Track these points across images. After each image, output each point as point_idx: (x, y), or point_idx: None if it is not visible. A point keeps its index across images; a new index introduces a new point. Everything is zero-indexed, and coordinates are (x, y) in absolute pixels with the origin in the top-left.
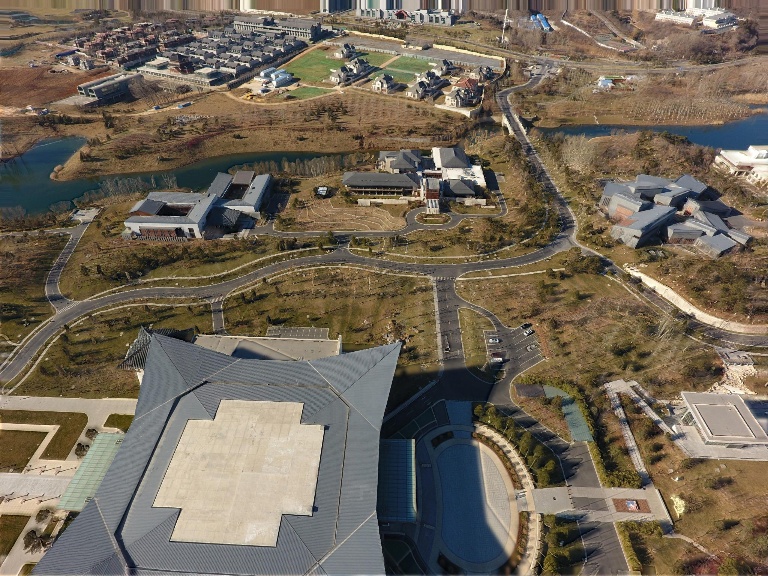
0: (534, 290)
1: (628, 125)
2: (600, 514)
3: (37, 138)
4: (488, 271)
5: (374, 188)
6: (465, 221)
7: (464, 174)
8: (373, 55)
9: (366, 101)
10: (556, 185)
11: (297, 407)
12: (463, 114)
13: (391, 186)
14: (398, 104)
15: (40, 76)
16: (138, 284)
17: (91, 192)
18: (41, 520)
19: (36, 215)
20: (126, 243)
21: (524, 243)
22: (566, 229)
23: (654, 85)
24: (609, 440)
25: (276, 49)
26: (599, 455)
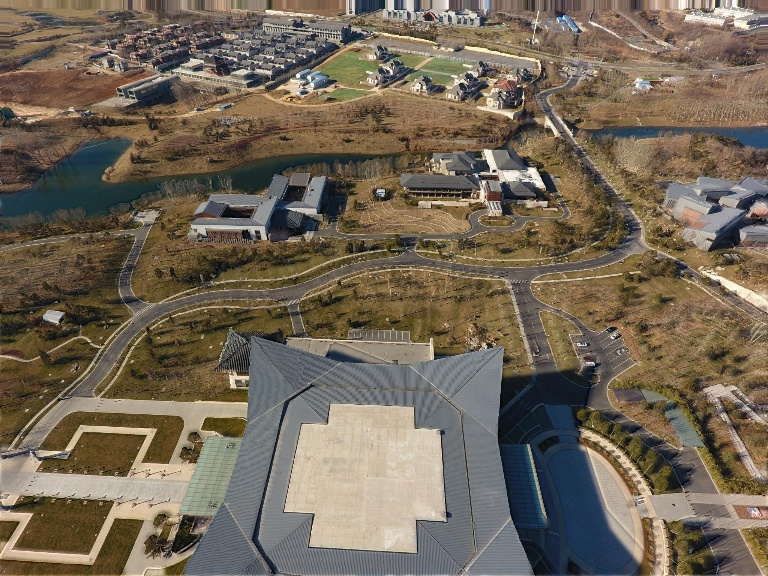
0: (613, 293)
1: (671, 127)
2: (723, 521)
3: (82, 140)
4: (562, 274)
5: (433, 190)
6: (529, 223)
7: (521, 176)
8: (406, 57)
9: (407, 103)
10: (614, 187)
11: (408, 411)
12: (506, 116)
13: (451, 188)
14: (440, 106)
15: (76, 78)
16: (210, 286)
17: (149, 194)
18: (159, 524)
19: (94, 217)
20: (192, 245)
21: (594, 246)
22: (633, 232)
23: (691, 87)
24: (719, 446)
25: (309, 51)
26: (713, 461)
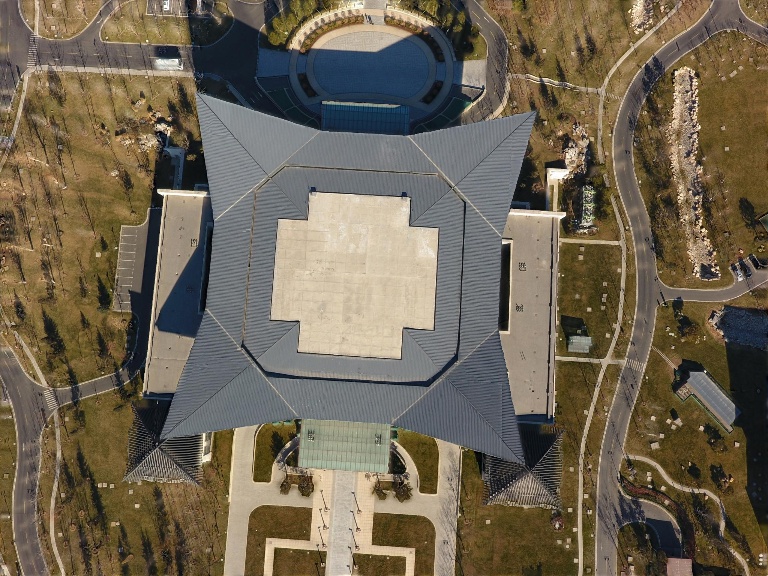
0: None
1: None
2: None
3: None
4: None
5: None
6: None
7: None
8: None
9: None
10: None
11: (285, 226)
12: None
13: None
14: None
15: None
16: (1, 543)
17: None
18: None
19: None
20: None
21: None
22: None
23: None
24: None
25: None
26: None
